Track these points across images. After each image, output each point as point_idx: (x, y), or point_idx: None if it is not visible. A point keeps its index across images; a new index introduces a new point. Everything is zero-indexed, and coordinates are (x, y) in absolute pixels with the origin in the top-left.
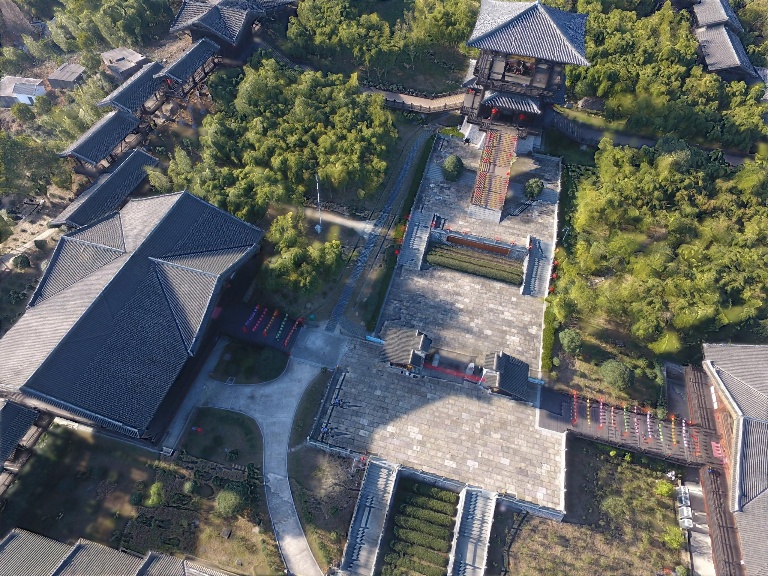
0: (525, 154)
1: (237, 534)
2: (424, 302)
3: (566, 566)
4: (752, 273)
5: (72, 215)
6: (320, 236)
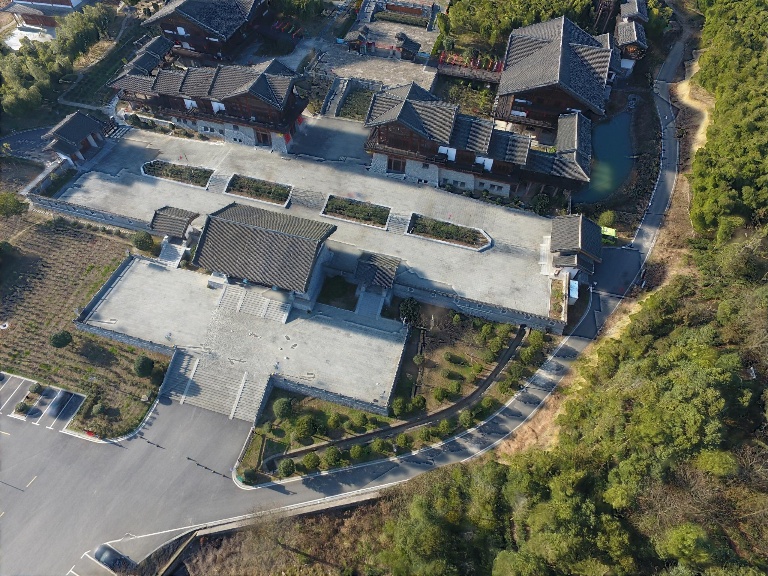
0: None
1: None
2: (370, 33)
3: None
4: (549, 6)
5: None
6: None
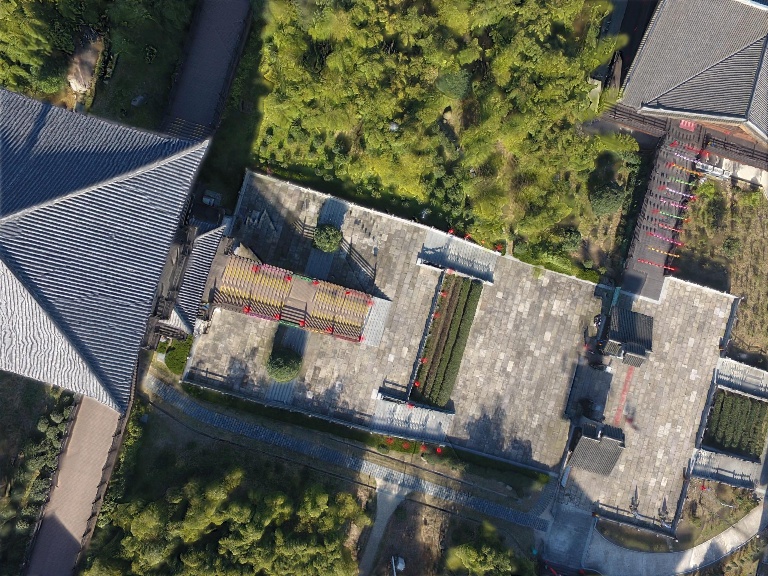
0: (236, 232)
1: None
2: (505, 411)
3: (760, 298)
4: None
5: None
6: (407, 557)
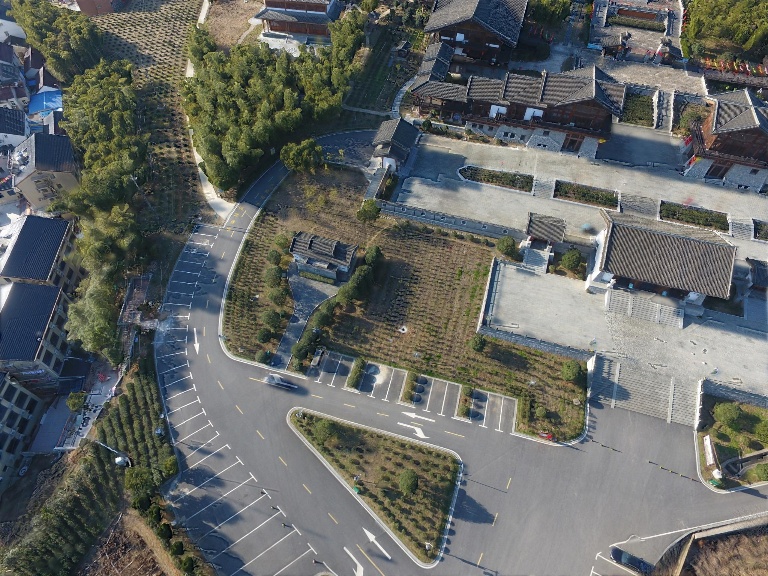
0: None
1: None
2: None
3: None
4: None
5: None
6: None
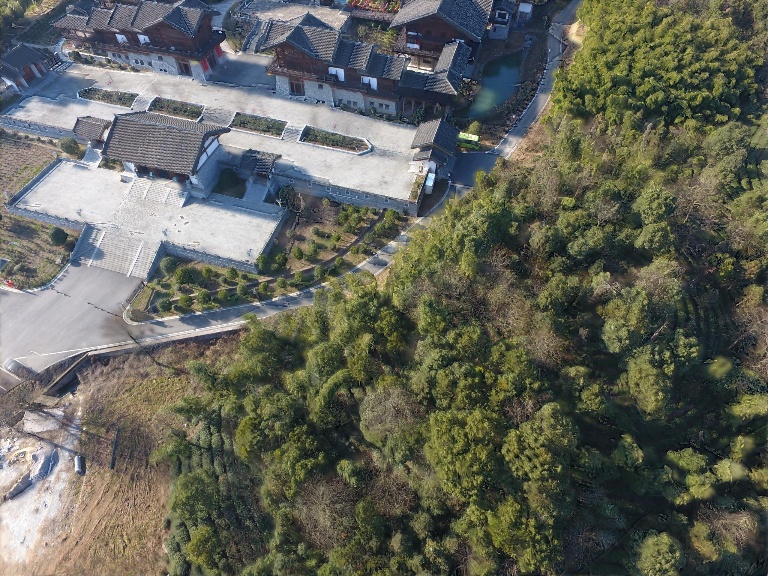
0: None
1: None
2: None
3: None
4: None
5: None
6: None
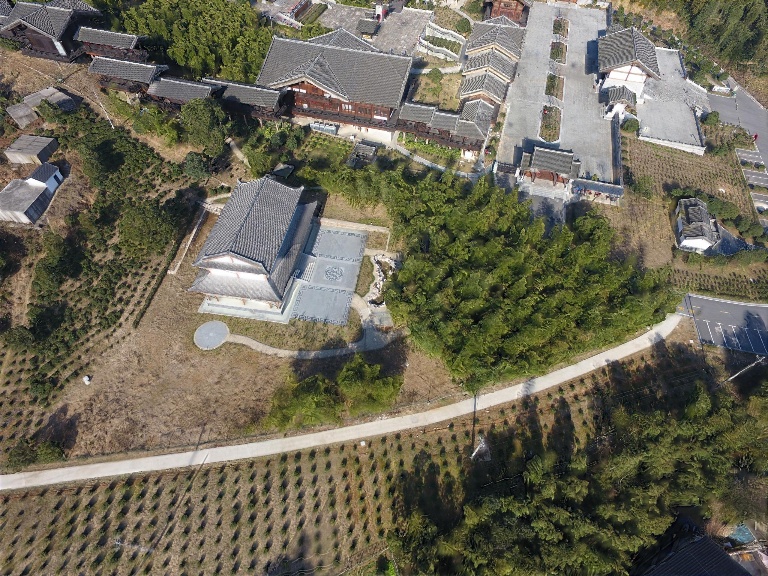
0: None
1: (447, 83)
2: None
3: None
4: None
5: (274, 91)
6: None
